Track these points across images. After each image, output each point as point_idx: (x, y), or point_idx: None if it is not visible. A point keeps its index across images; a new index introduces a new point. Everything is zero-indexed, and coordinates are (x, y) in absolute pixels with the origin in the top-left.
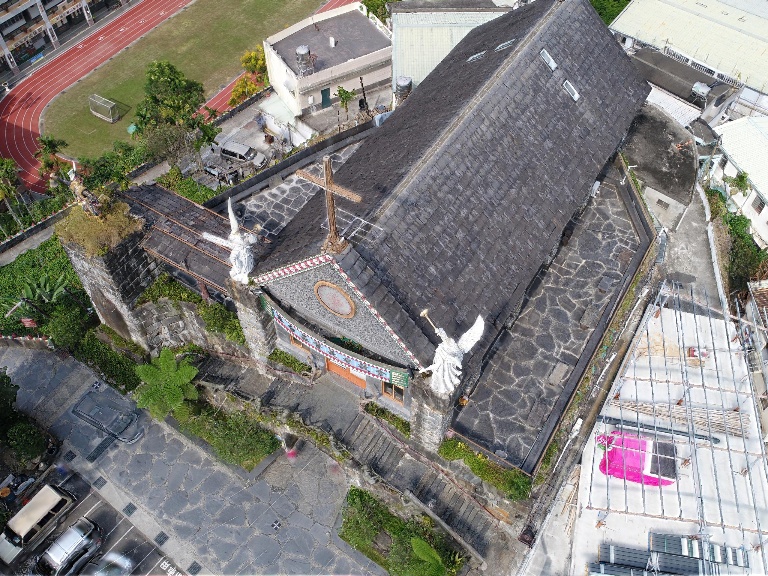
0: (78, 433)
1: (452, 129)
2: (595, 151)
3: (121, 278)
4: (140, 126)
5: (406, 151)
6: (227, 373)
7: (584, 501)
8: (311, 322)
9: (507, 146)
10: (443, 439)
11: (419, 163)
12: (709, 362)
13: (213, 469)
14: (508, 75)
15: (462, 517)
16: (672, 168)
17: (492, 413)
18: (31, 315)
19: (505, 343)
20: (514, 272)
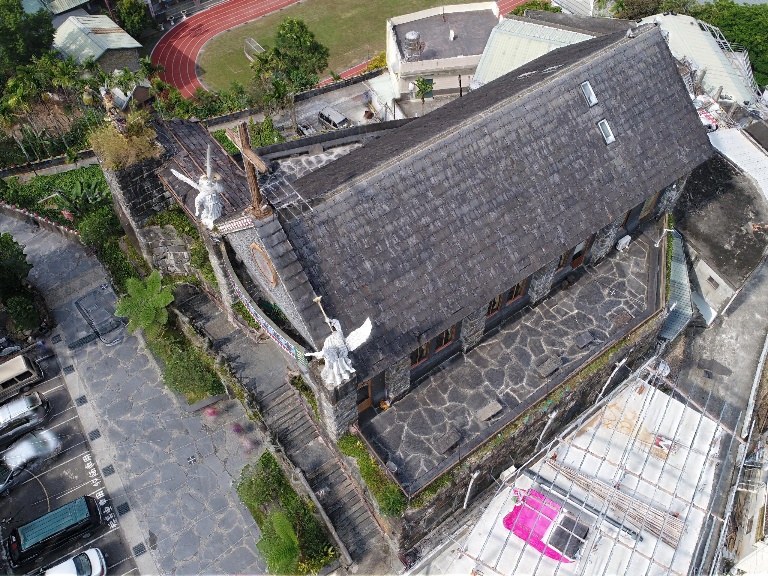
0: (71, 322)
1: (443, 136)
2: (612, 200)
3: (132, 196)
4: (257, 74)
5: (399, 147)
6: (206, 311)
7: (472, 545)
8: (255, 282)
9: (503, 168)
10: (346, 433)
11: (393, 159)
12: (673, 457)
13: (163, 391)
14: (532, 98)
15: (351, 515)
16: (736, 247)
17: (408, 426)
18: (73, 210)
19: (454, 365)
20: (462, 294)
